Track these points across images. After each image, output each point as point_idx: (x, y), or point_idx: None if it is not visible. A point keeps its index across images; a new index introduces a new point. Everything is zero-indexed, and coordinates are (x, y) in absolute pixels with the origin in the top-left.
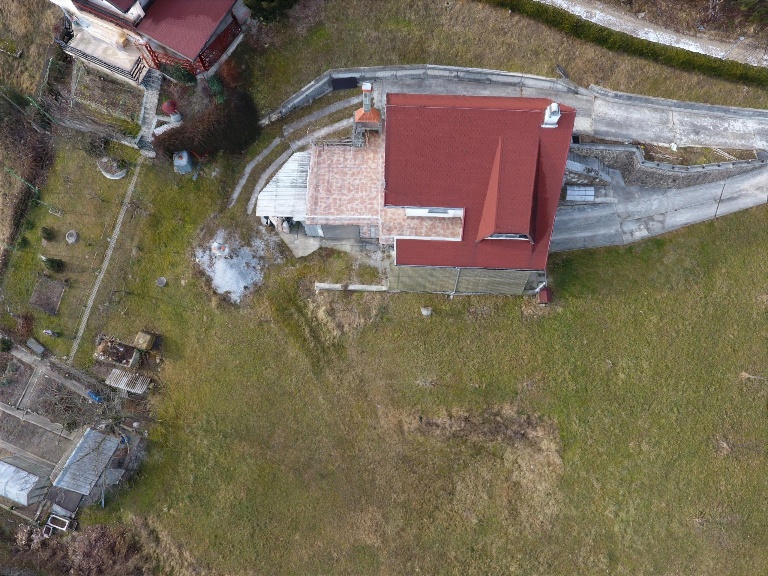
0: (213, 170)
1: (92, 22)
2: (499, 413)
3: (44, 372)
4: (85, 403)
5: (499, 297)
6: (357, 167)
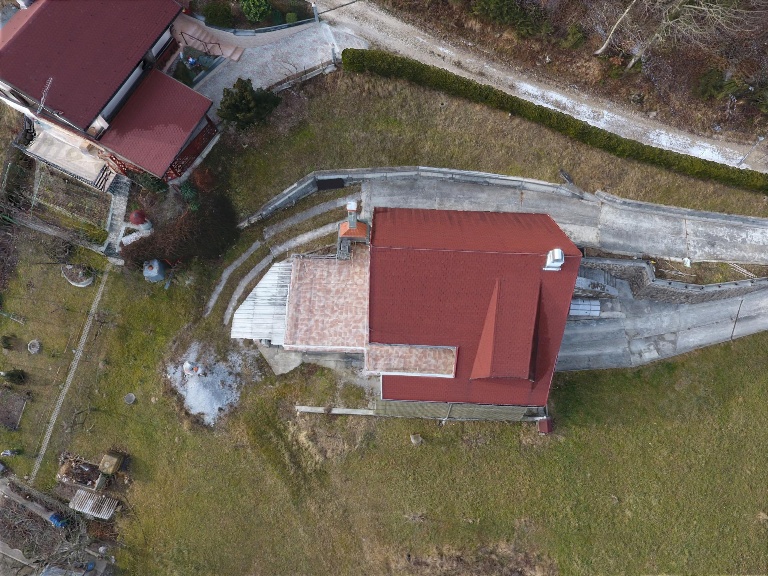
0: (187, 278)
1: (53, 127)
2: (494, 551)
3: (3, 492)
4: (47, 526)
5: (495, 423)
6: (342, 283)
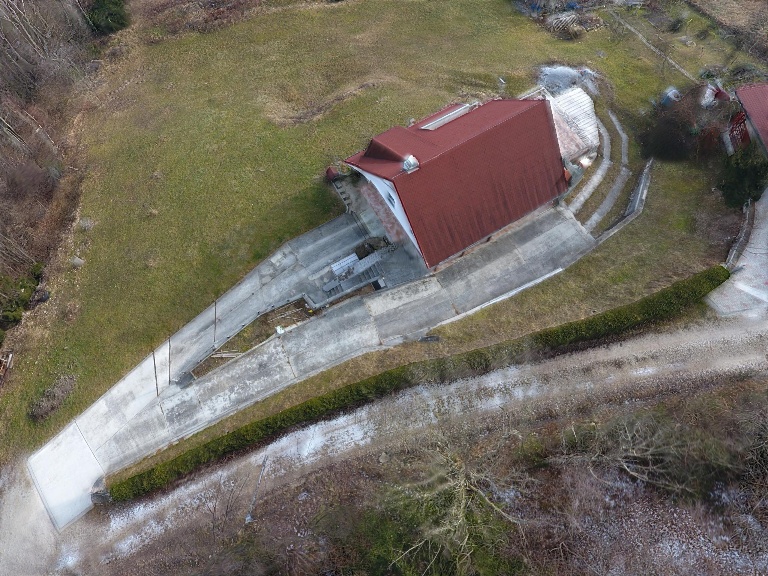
0: None
1: None
2: None
3: (620, 4)
4: None
5: None
6: None
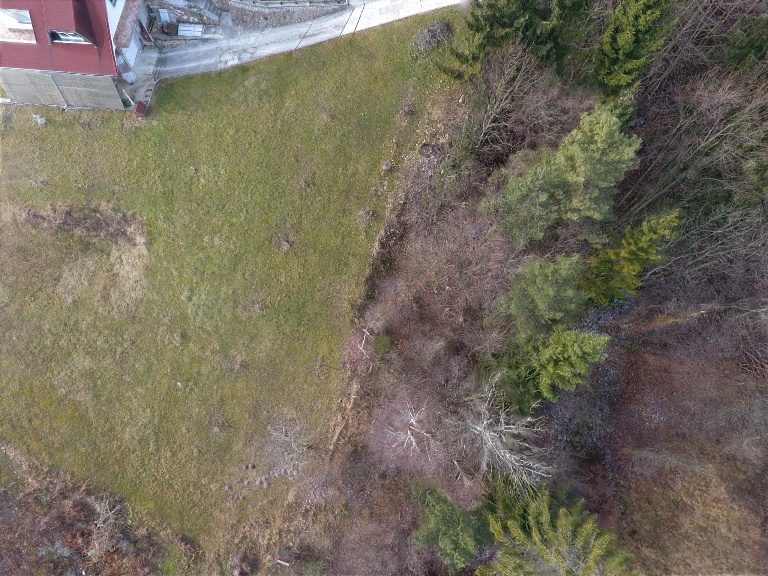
0: None
1: None
2: (97, 210)
3: None
4: None
5: (106, 112)
6: None
